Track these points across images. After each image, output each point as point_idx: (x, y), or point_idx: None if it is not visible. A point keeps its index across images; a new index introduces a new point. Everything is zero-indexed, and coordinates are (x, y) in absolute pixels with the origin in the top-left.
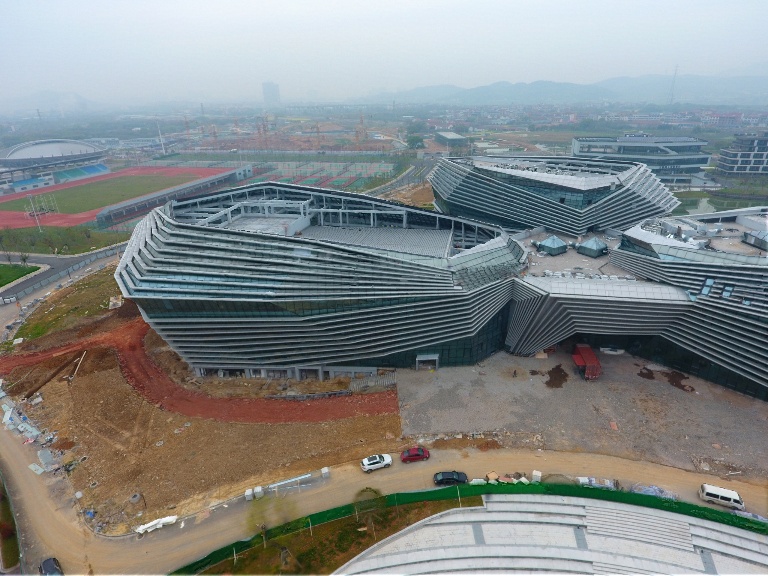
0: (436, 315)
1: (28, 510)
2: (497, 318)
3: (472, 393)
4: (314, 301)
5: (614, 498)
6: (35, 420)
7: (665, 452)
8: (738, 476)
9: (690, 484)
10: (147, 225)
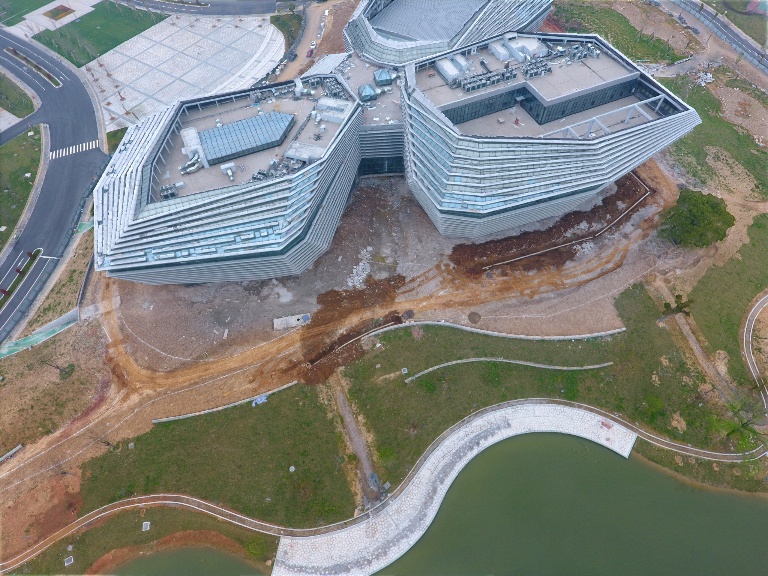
0: None
1: None
2: None
3: None
4: None
5: None
6: None
7: None
8: None
9: None
10: None
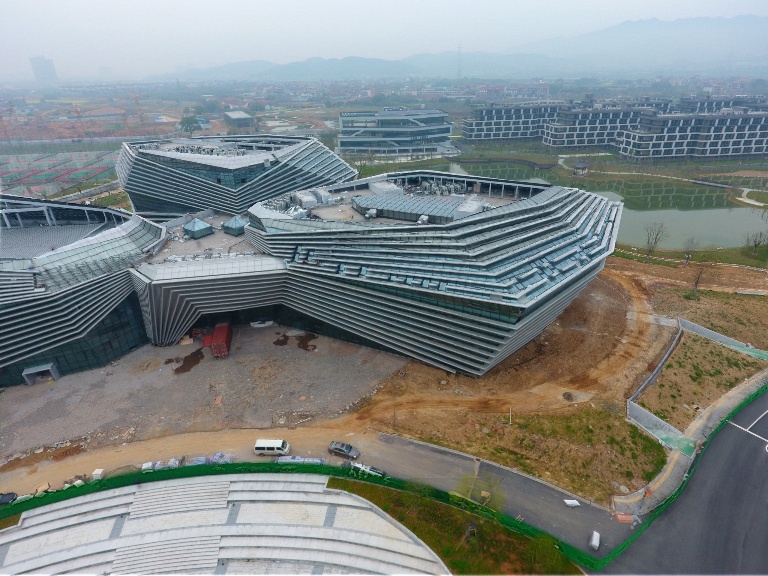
0: (21, 323)
1: None
2: (124, 312)
3: (84, 398)
4: None
5: (168, 476)
6: None
7: (252, 415)
8: (304, 423)
9: None
10: None
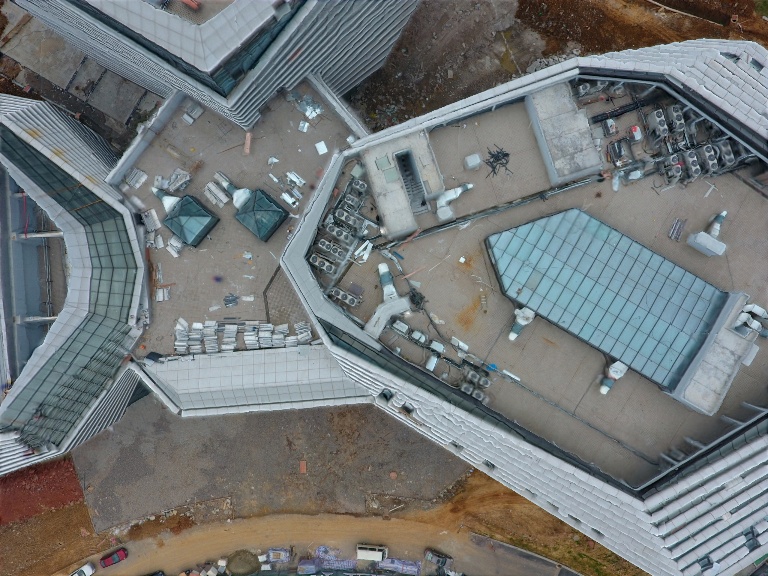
0: None
1: None
2: None
3: (157, 447)
4: None
5: None
6: None
7: (344, 495)
8: (398, 513)
9: (354, 535)
10: None
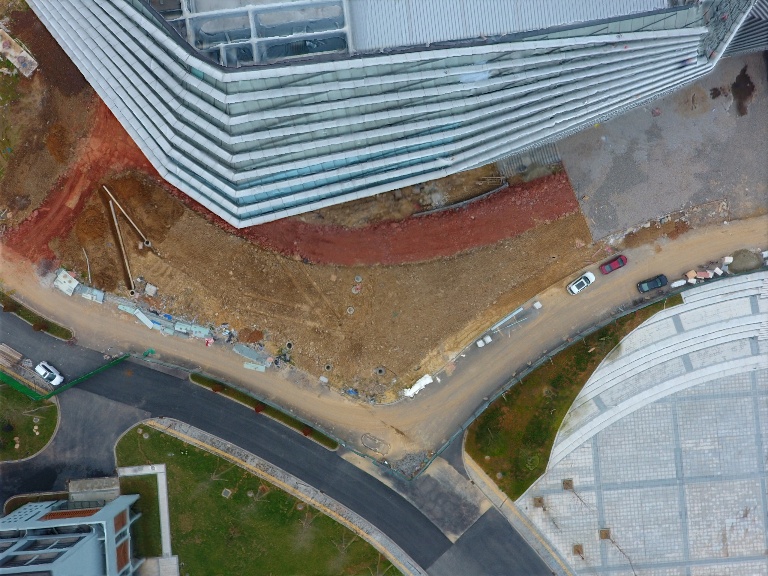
0: None
1: (295, 404)
2: None
3: (650, 154)
4: (506, 152)
5: None
6: (184, 317)
7: None
8: None
9: None
10: (86, 18)
